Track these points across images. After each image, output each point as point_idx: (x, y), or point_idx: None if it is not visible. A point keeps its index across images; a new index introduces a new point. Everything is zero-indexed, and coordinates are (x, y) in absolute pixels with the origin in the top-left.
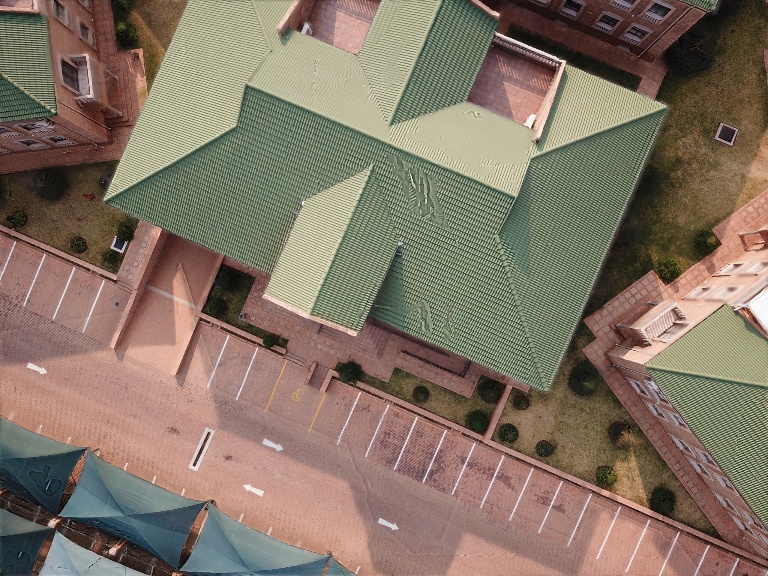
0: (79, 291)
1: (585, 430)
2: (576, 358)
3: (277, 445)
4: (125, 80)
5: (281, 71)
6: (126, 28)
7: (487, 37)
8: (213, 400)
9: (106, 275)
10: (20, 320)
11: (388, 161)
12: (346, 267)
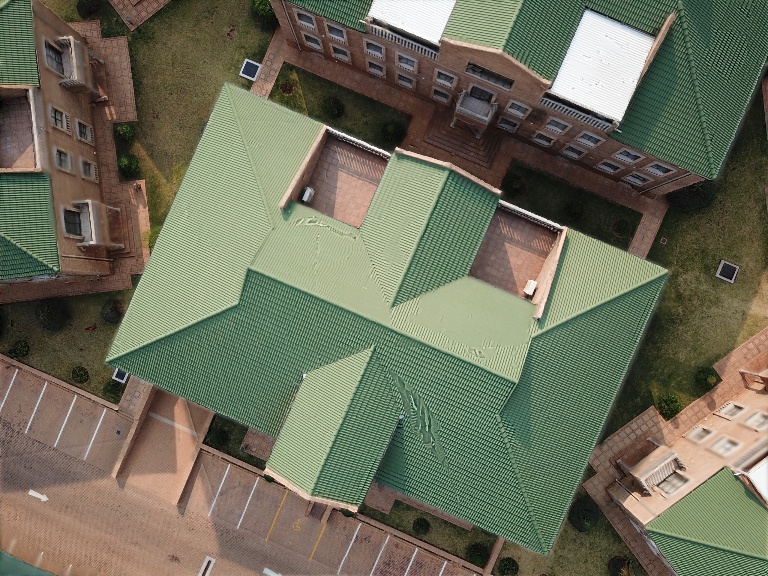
0: (81, 419)
1: (585, 565)
2: (576, 493)
3: (277, 574)
4: (127, 211)
5: (283, 251)
6: (128, 160)
7: (489, 212)
8: (214, 529)
9: (108, 405)
10: (22, 447)
11: (389, 343)
12: (347, 445)
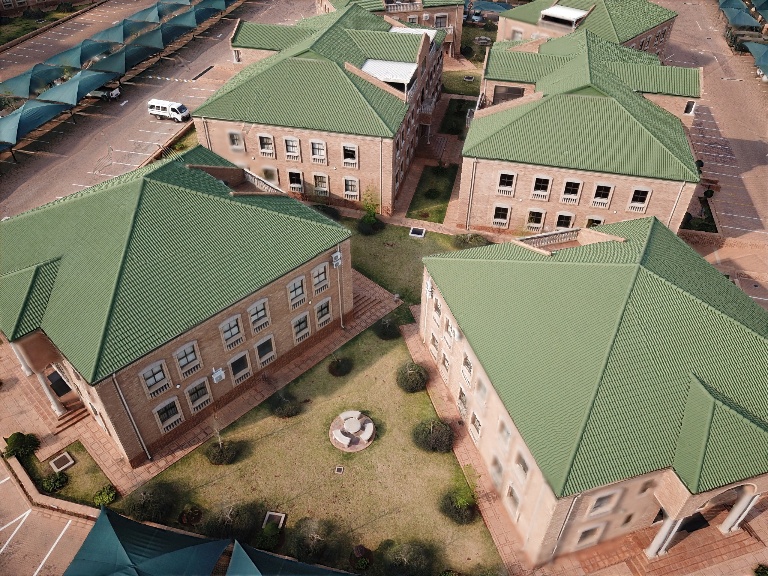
0: None
1: None
2: None
3: None
4: None
5: None
6: None
7: None
8: None
9: None
10: None
11: None
12: None
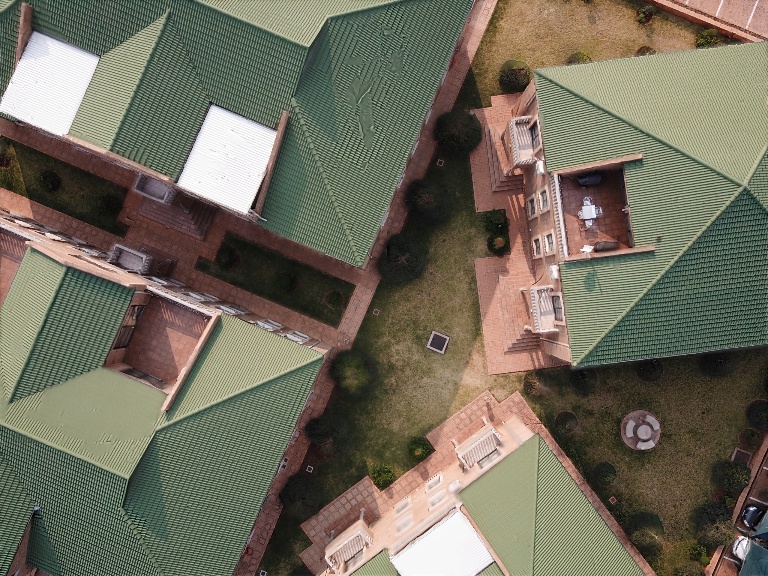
0: None
1: None
2: (293, 563)
3: None
4: None
5: None
6: None
7: (122, 304)
8: None
9: None
10: None
11: (7, 439)
12: None
